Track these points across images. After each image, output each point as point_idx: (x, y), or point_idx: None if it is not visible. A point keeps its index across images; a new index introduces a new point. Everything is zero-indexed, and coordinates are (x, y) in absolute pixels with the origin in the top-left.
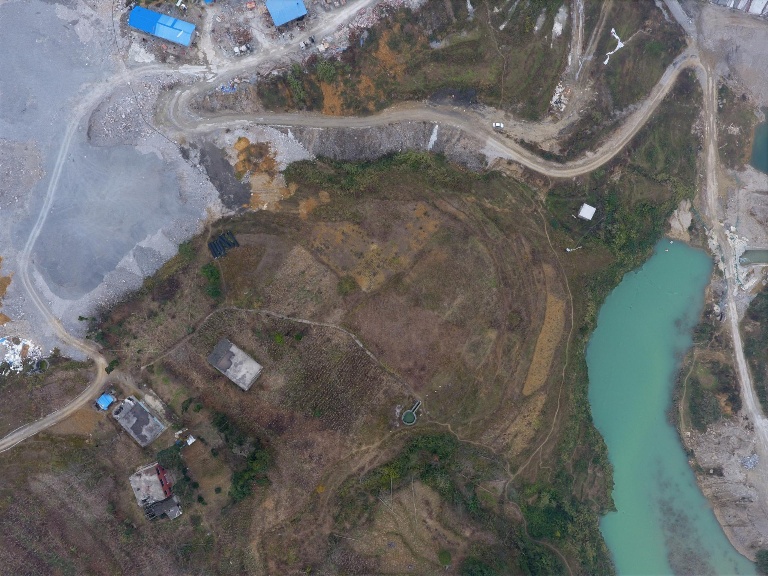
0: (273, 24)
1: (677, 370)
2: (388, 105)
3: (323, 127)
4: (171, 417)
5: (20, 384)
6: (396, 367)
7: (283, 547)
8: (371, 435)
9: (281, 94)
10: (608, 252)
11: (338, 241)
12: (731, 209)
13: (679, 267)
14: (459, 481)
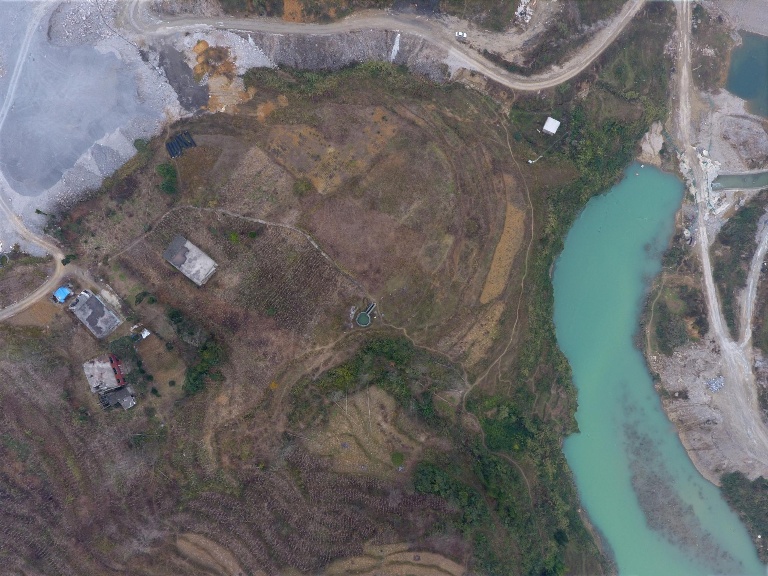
0: None
1: (645, 294)
2: (350, 13)
3: (283, 33)
4: (127, 312)
5: None
6: (351, 269)
7: (237, 443)
8: (325, 336)
9: None
10: (572, 166)
11: (295, 143)
12: (704, 132)
13: (650, 192)
14: (416, 389)
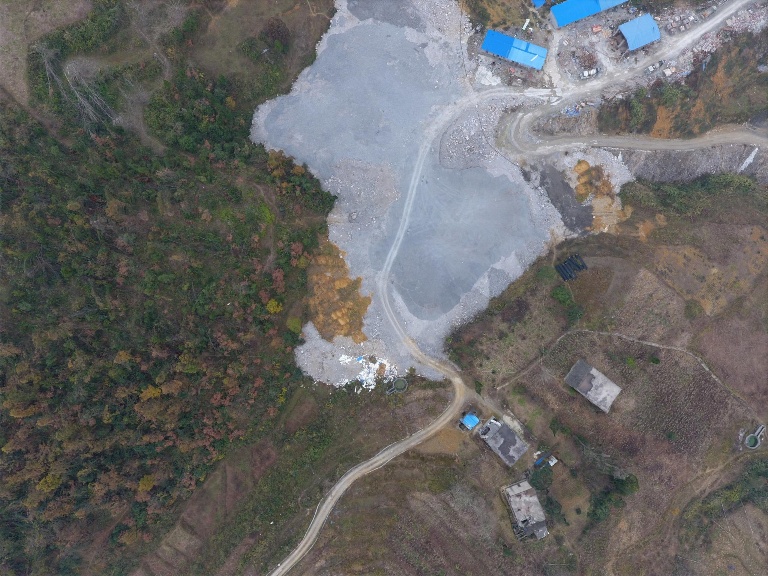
0: (618, 48)
1: None
2: (711, 128)
3: (651, 150)
4: (530, 438)
5: (378, 402)
6: (740, 391)
7: (633, 568)
8: (716, 458)
9: (618, 117)
10: None
11: (680, 265)
12: None
13: None
14: None
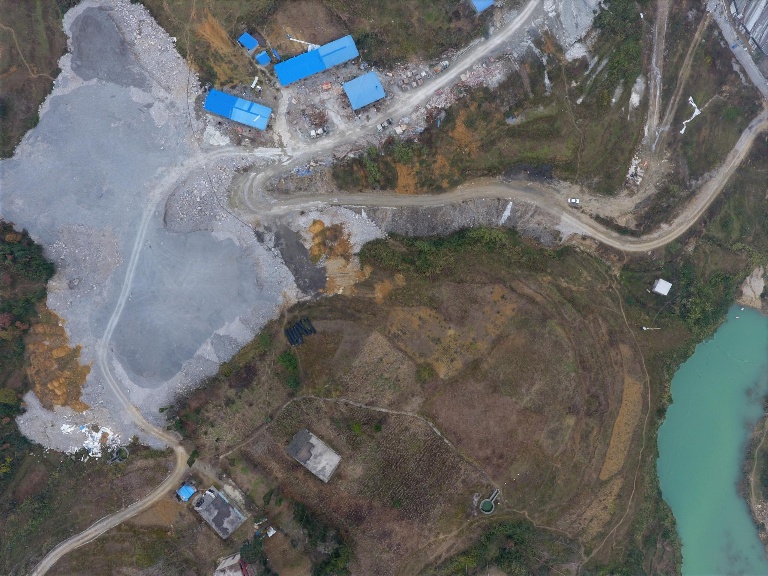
0: (349, 105)
1: (747, 441)
2: (462, 182)
3: (397, 206)
4: (250, 507)
5: (100, 472)
6: (474, 455)
7: None
8: (449, 524)
9: (356, 175)
10: (684, 328)
11: (415, 326)
12: None
13: (749, 333)
14: (533, 564)
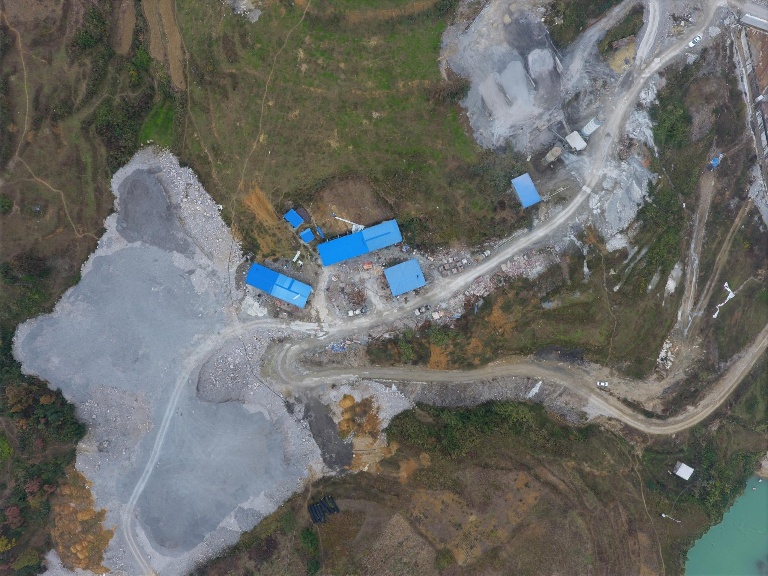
0: (388, 286)
1: None
2: (493, 359)
3: (427, 381)
4: None
5: None
6: None
7: None
8: None
9: (389, 352)
10: (702, 513)
11: (437, 510)
12: None
13: (765, 504)
14: None
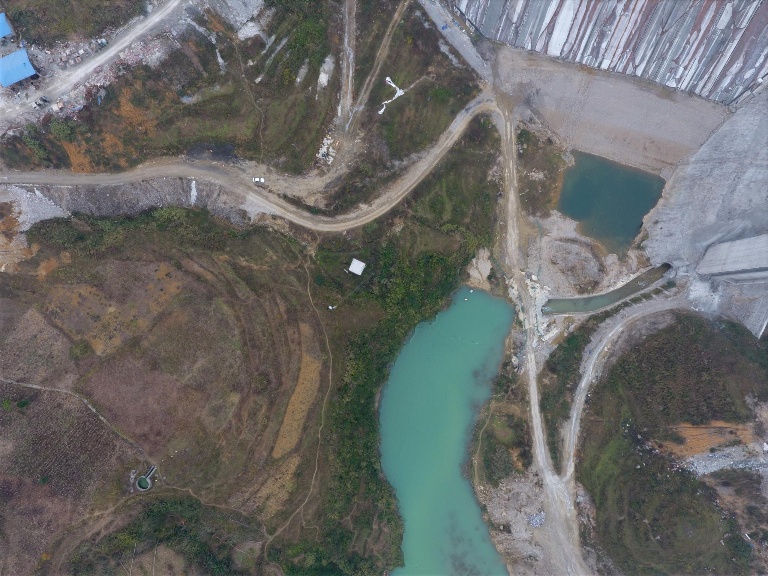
0: None
1: (473, 423)
2: (142, 161)
3: (72, 185)
4: None
5: None
6: (130, 432)
7: None
8: (104, 501)
9: (22, 153)
10: (379, 308)
11: (74, 304)
12: (532, 257)
13: (482, 316)
14: (212, 543)
